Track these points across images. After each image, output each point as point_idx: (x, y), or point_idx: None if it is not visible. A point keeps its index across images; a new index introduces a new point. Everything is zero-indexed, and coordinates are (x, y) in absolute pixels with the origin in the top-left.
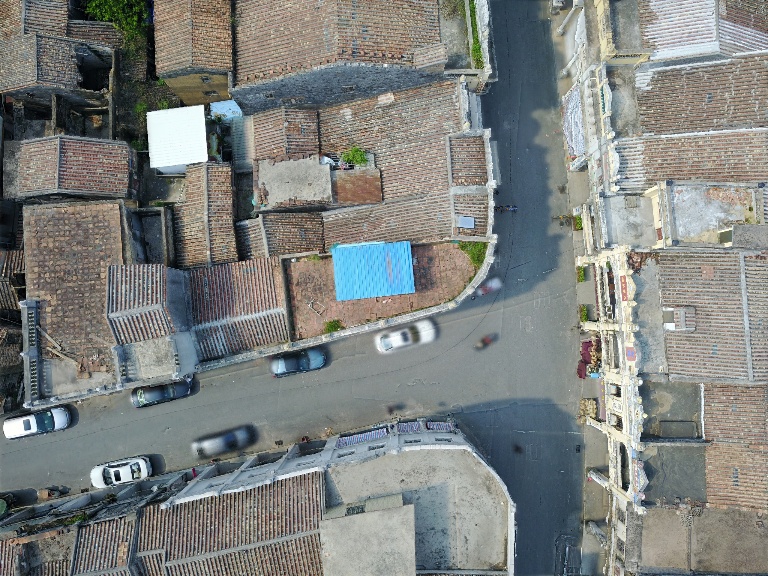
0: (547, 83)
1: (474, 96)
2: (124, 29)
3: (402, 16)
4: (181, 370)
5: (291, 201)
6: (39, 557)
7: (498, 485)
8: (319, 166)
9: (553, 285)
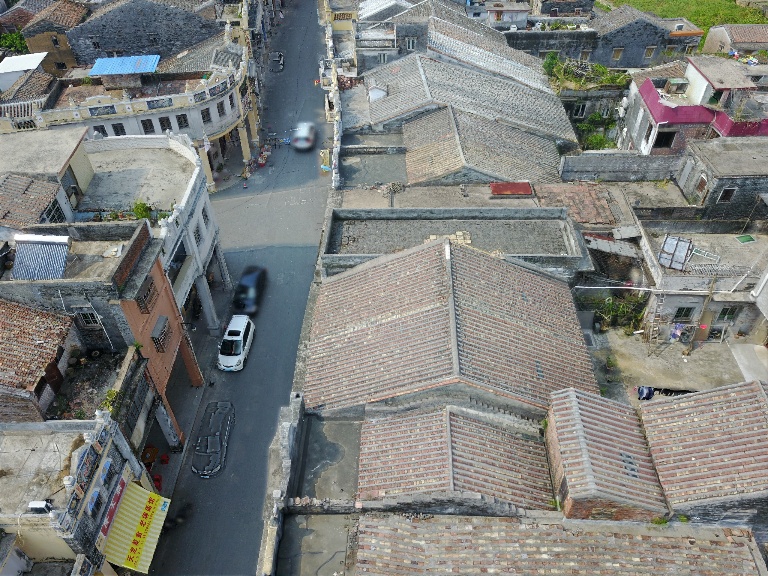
0: (324, 100)
1: None
2: (19, 54)
3: (195, 6)
4: None
5: None
6: None
7: (194, 167)
8: None
9: (318, 181)
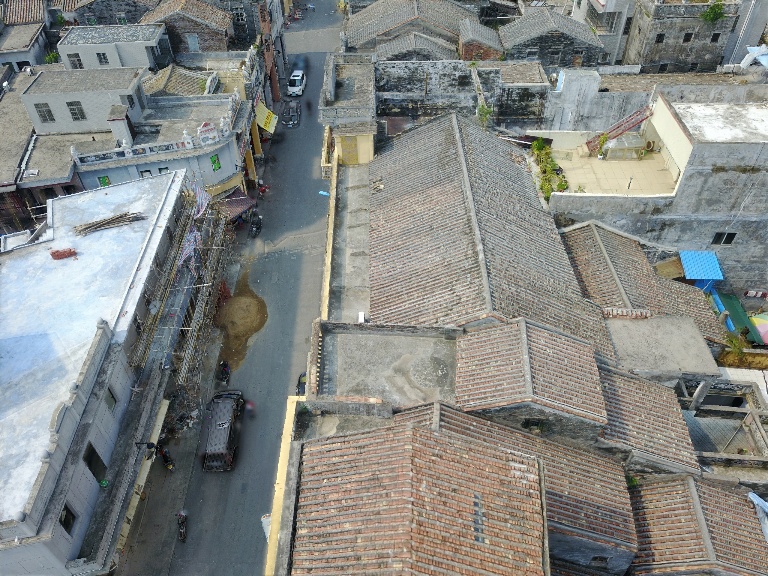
0: None
1: None
2: None
3: None
4: None
5: None
6: None
7: None
8: None
9: (335, 25)
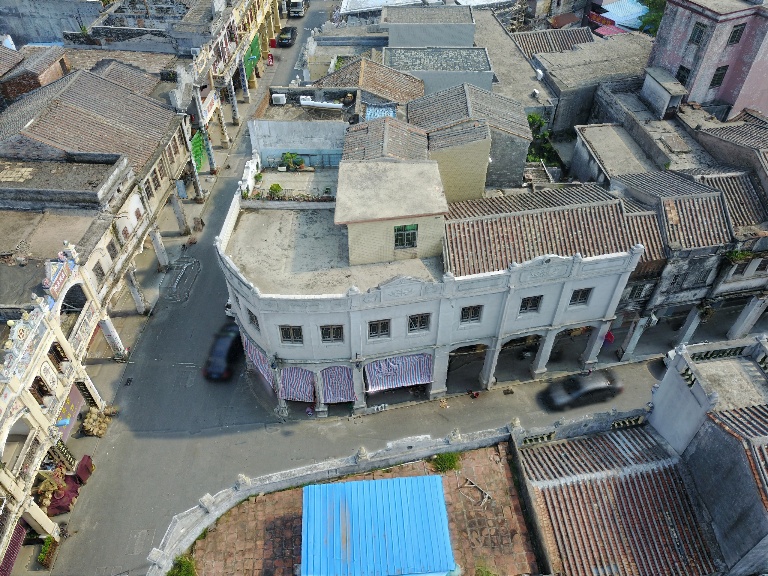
0: None
1: None
2: None
3: None
4: (675, 371)
5: None
6: (766, 229)
7: None
8: None
9: None
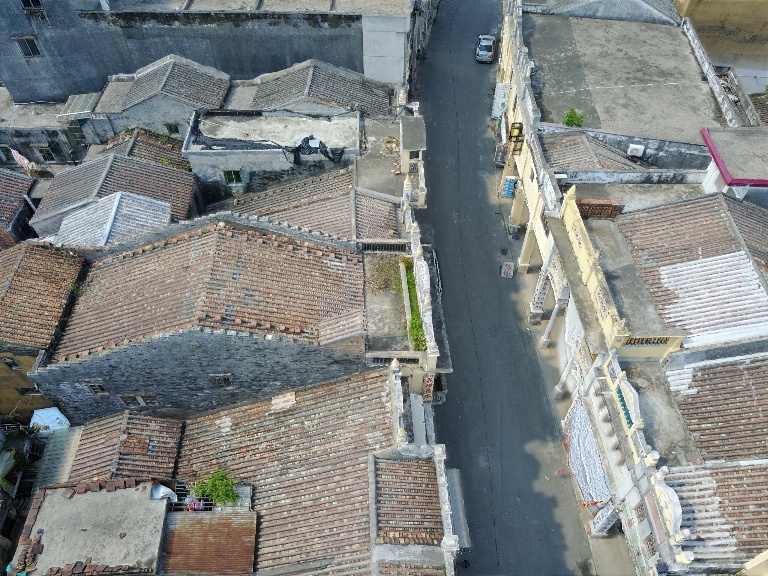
0: (536, 405)
1: (420, 399)
2: None
3: (310, 284)
4: None
5: (78, 566)
6: None
7: None
8: (148, 502)
9: None
